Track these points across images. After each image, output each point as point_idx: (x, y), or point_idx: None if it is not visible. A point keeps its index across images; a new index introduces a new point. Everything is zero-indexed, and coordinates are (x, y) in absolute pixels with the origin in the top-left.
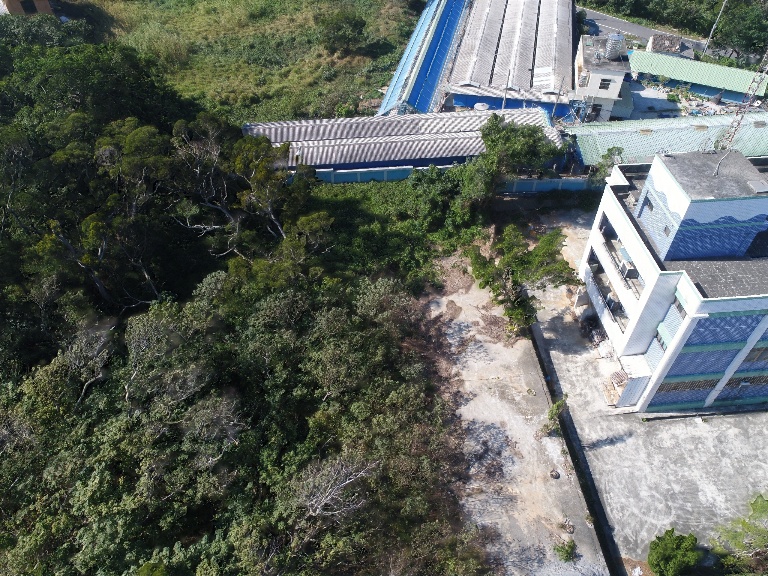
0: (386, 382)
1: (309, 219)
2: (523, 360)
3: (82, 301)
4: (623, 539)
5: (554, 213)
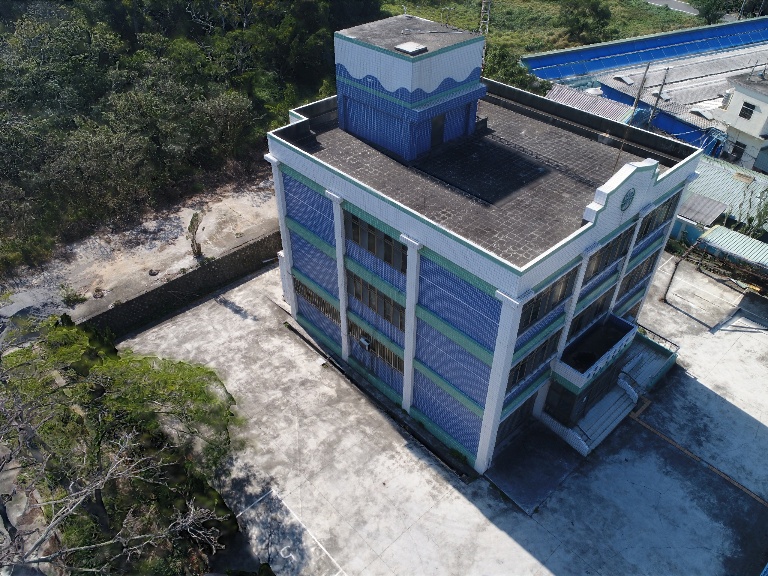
0: (133, 128)
1: (238, 31)
2: (275, 220)
3: (93, 15)
4: (126, 347)
5: None
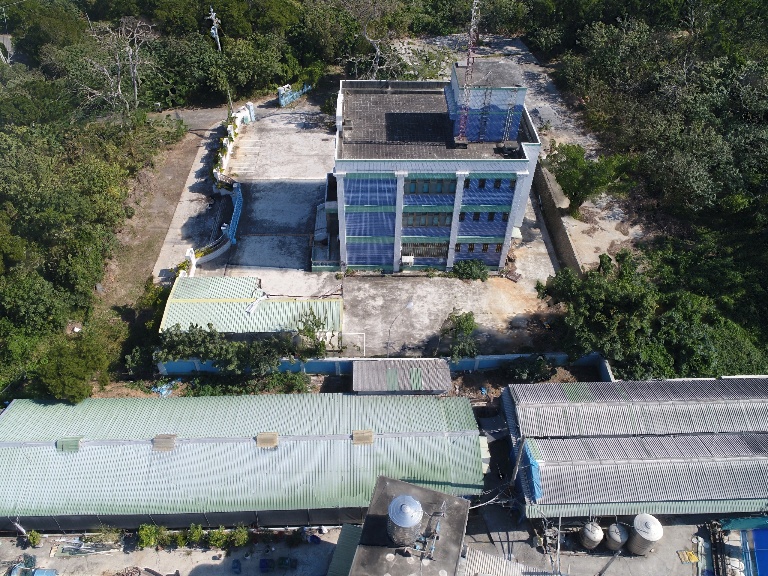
0: None
1: None
2: (564, 196)
3: None
4: None
5: (515, 348)
